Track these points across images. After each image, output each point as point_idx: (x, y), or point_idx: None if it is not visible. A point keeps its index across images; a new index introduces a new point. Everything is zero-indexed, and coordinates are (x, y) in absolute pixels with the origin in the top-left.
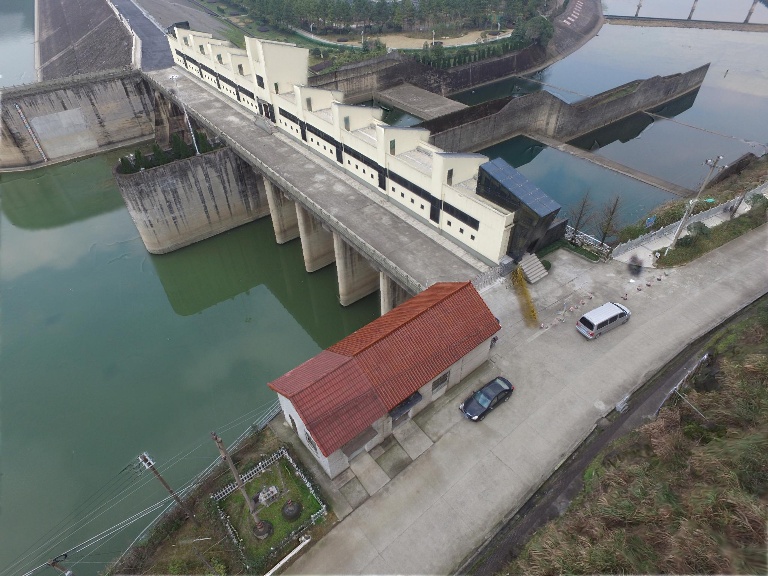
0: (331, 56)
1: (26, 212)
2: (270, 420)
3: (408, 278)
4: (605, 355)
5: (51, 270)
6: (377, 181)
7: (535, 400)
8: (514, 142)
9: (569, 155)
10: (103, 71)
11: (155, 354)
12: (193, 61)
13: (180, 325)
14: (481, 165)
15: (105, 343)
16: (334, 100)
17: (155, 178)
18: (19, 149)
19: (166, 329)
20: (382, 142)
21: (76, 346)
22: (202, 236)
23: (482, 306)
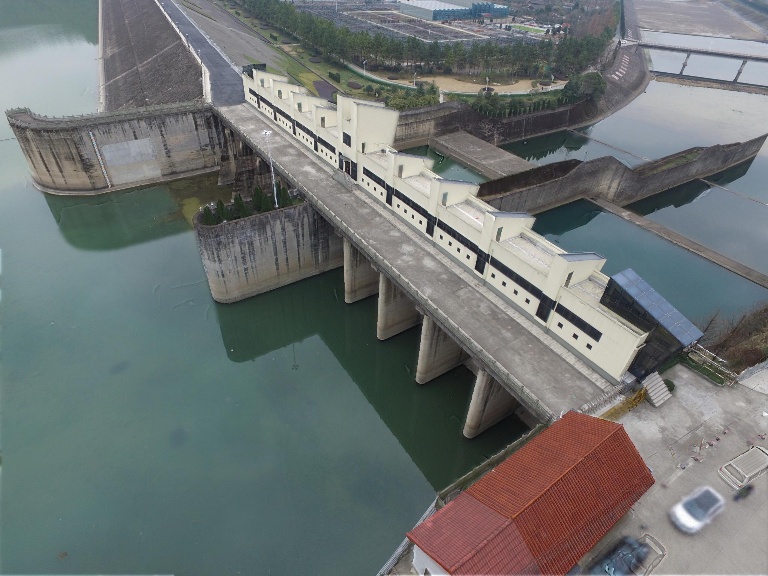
0: (384, 94)
1: (89, 241)
2: (395, 563)
3: (524, 389)
4: (756, 513)
5: (115, 310)
6: (474, 263)
7: (689, 568)
8: (576, 205)
9: (635, 225)
10: (175, 103)
11: (224, 422)
12: (268, 103)
13: (248, 389)
14: (613, 277)
15: (172, 403)
16: (425, 168)
17: (235, 231)
18: (86, 174)
19: (235, 393)
20: (490, 229)
21: (141, 403)
22: (269, 287)
23: (635, 454)
